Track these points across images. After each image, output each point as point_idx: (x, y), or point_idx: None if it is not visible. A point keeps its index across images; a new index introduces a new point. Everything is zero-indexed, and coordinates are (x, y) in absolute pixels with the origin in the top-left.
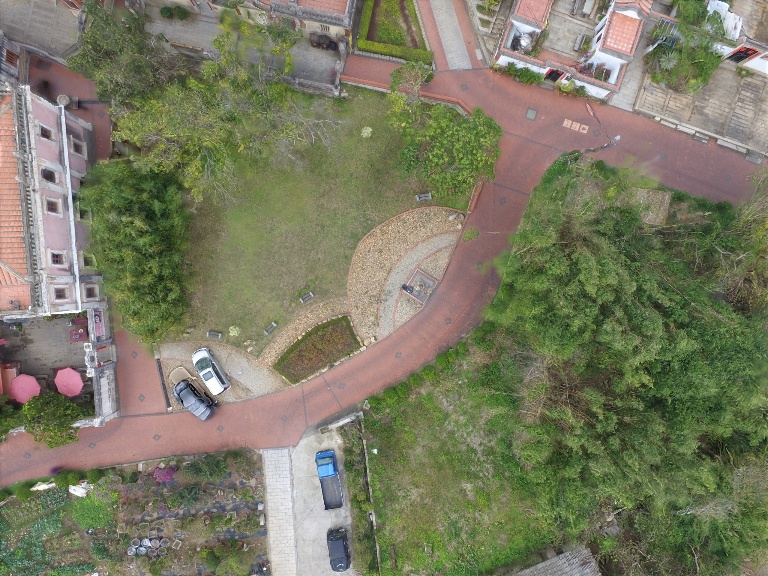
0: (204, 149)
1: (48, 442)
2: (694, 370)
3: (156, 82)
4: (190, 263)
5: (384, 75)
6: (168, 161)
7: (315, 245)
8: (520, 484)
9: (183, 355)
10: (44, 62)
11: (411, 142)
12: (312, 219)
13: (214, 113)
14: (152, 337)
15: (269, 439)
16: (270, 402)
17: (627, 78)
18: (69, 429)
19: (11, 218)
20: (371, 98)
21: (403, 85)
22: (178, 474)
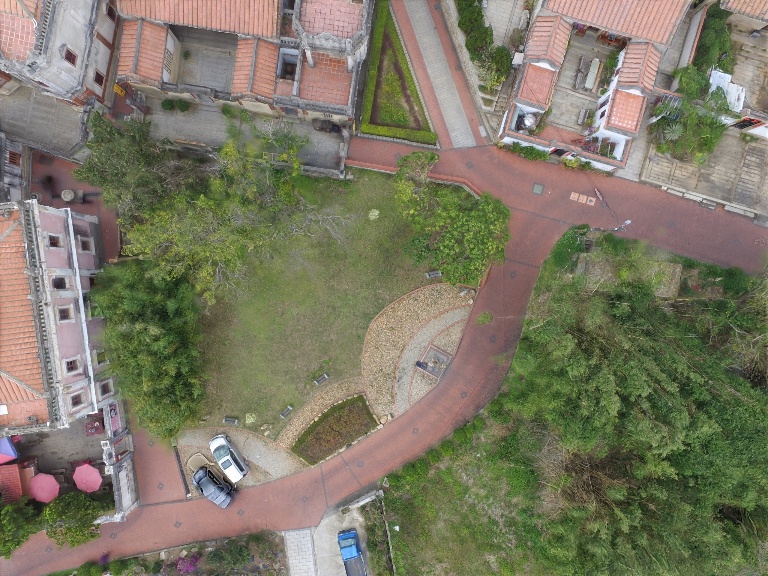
0: (215, 254)
1: (70, 541)
2: (715, 449)
3: (164, 192)
4: (203, 351)
5: (389, 156)
6: (179, 266)
7: (327, 326)
8: (543, 554)
9: (200, 442)
10: (46, 157)
11: (420, 230)
12: (323, 301)
13: (225, 226)
14: (170, 435)
15: (290, 521)
16: (289, 484)
17: (632, 149)
18: (90, 526)
19: (25, 334)
20: (376, 179)
21: (410, 174)
22: (201, 560)
